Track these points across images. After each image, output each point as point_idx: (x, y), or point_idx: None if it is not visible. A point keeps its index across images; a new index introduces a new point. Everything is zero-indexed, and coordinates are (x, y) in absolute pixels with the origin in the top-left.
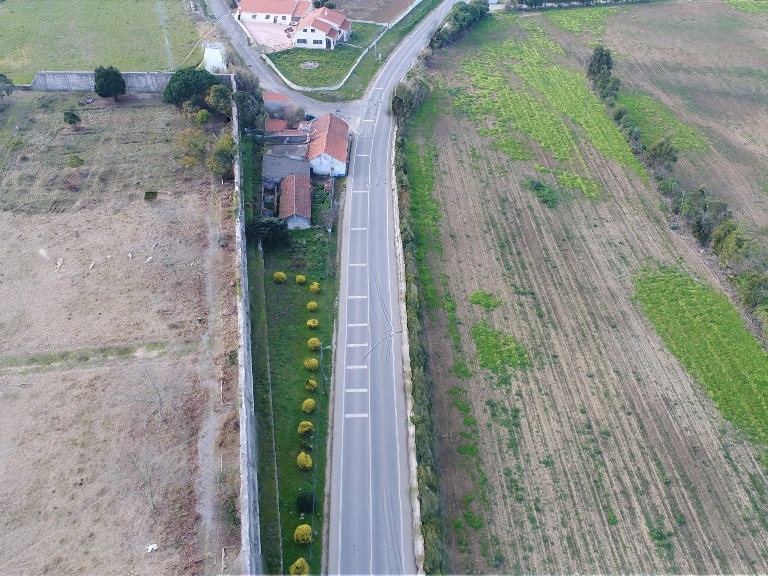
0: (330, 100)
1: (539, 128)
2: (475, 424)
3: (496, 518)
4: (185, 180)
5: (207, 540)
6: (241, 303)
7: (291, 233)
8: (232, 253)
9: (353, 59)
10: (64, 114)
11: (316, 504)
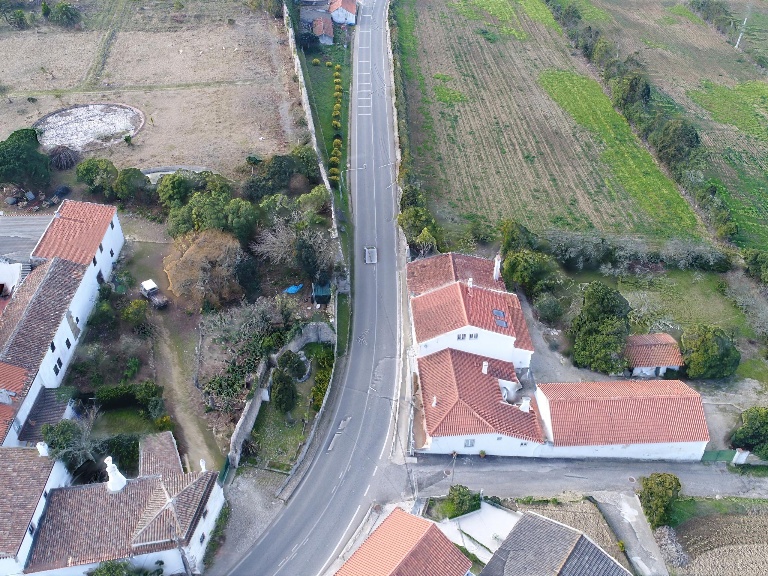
0: None
1: (490, 5)
2: (432, 119)
3: (440, 148)
4: (251, 17)
5: (290, 137)
6: (297, 56)
7: (321, 44)
8: (287, 47)
9: None
10: None
11: (344, 140)
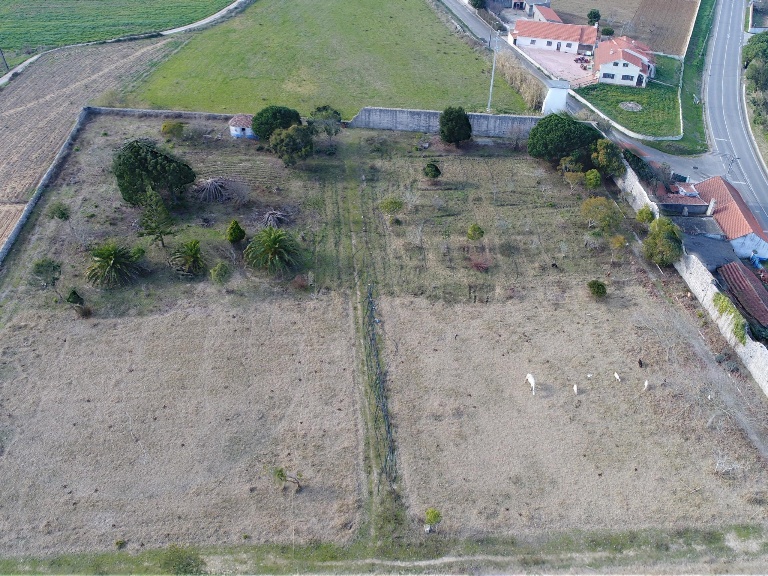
0: (678, 153)
1: None
2: None
3: None
4: (613, 264)
5: None
6: None
7: None
8: (748, 382)
9: (673, 100)
10: (427, 166)
11: None
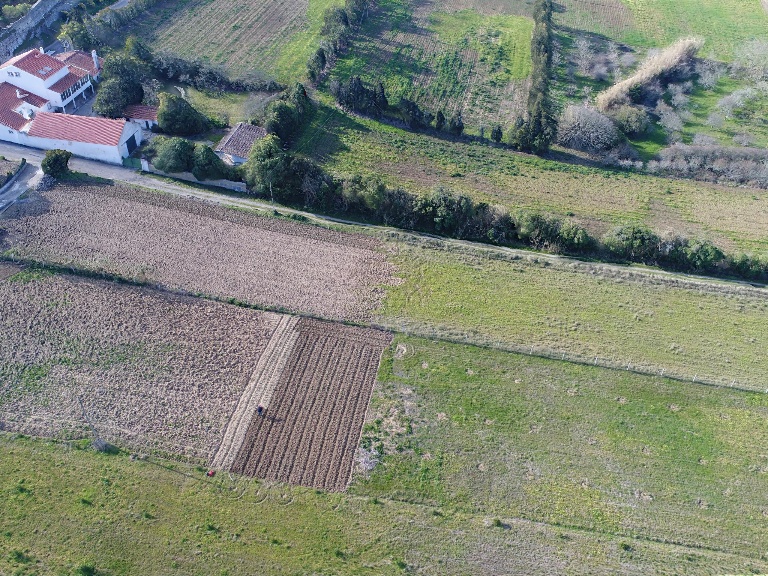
0: None
1: None
2: None
3: (176, 13)
4: None
5: None
6: None
7: None
8: None
9: None
10: None
11: (112, 0)
